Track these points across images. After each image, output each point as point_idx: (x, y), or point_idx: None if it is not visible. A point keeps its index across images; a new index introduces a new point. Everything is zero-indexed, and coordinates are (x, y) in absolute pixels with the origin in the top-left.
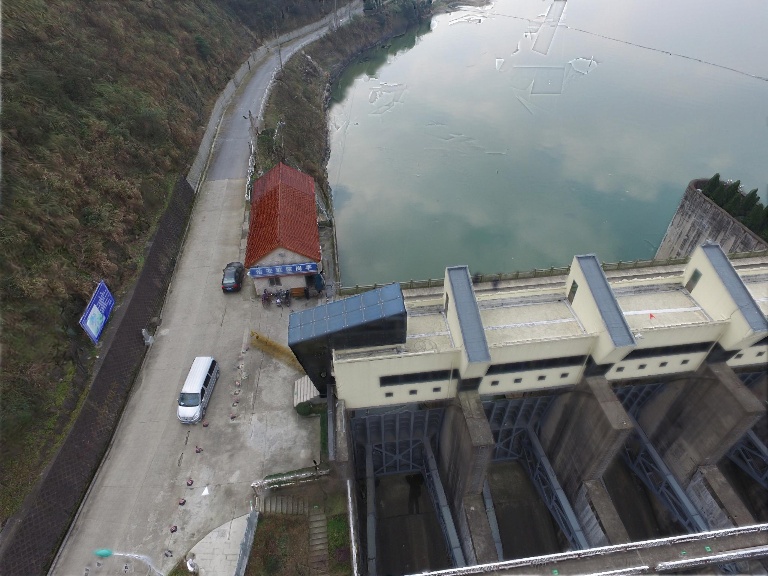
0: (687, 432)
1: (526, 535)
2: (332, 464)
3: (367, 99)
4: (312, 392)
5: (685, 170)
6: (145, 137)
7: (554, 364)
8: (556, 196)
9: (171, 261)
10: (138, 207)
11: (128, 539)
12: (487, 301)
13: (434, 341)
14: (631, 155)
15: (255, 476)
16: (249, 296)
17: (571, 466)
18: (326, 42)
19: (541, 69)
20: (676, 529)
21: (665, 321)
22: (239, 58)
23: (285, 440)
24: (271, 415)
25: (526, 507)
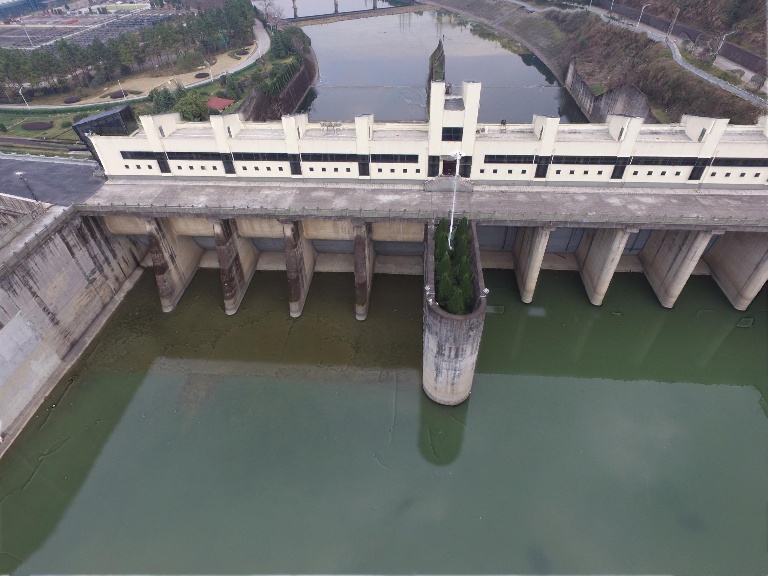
0: None
1: None
2: None
3: None
4: None
5: None
6: None
7: None
8: None
9: None
10: None
11: None
12: None
13: None
14: None
15: None
16: None
17: None
18: None
19: None
20: None
21: None
22: None
23: None
24: None
25: None
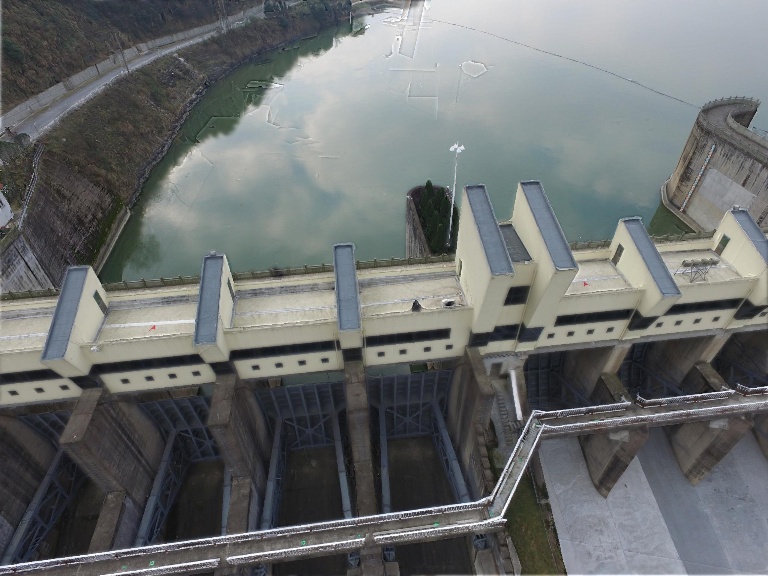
0: None
1: None
2: None
3: None
4: None
5: (505, 175)
6: None
7: (41, 376)
8: (363, 201)
9: None
10: None
11: None
12: (3, 312)
13: None
14: (461, 159)
15: None
16: None
17: None
18: (211, 44)
19: (416, 72)
20: None
21: (160, 333)
22: (88, 61)
23: None
24: None
25: None
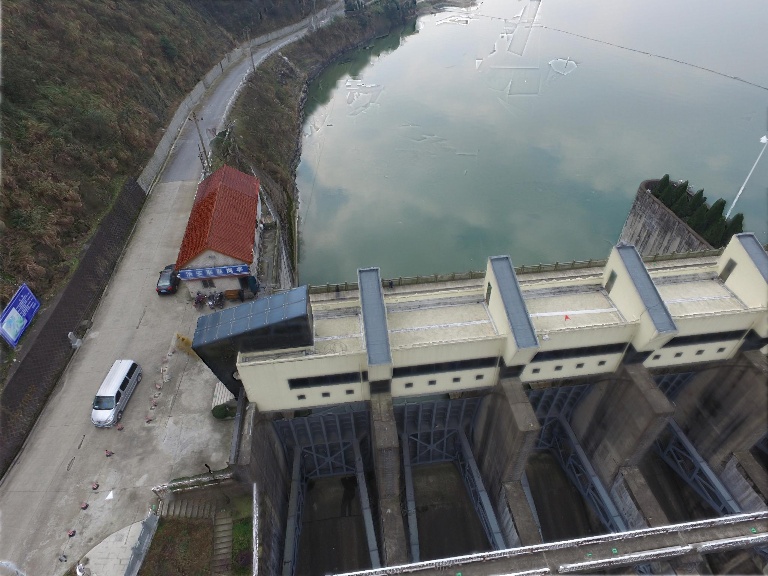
0: (610, 433)
1: (457, 537)
2: (234, 467)
3: (345, 100)
4: (229, 395)
5: (653, 170)
6: (91, 139)
7: (467, 366)
8: (522, 197)
9: (111, 263)
10: (77, 209)
11: (24, 544)
12: (405, 303)
13: (345, 343)
14: (601, 156)
15: (162, 480)
16: (184, 298)
17: (494, 468)
18: (305, 43)
19: (518, 70)
20: (604, 530)
21: (579, 322)
22: (212, 59)
23: (198, 443)
24: (187, 418)
25: (459, 509)
